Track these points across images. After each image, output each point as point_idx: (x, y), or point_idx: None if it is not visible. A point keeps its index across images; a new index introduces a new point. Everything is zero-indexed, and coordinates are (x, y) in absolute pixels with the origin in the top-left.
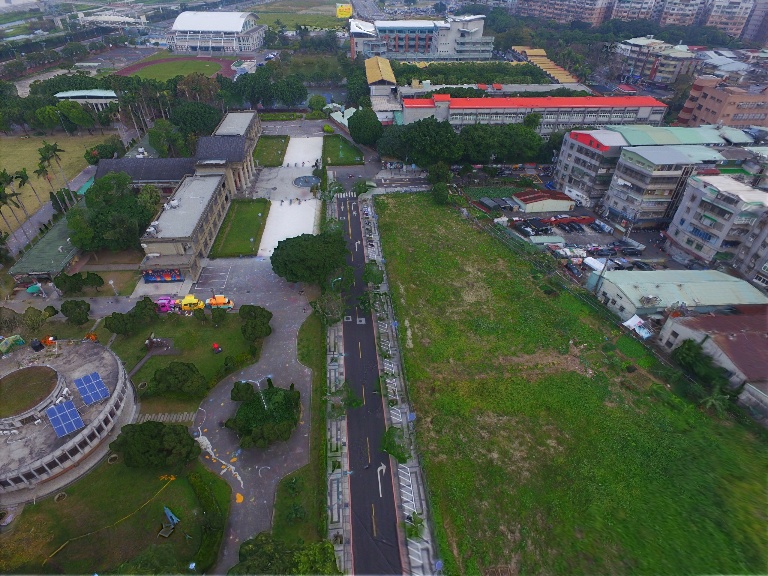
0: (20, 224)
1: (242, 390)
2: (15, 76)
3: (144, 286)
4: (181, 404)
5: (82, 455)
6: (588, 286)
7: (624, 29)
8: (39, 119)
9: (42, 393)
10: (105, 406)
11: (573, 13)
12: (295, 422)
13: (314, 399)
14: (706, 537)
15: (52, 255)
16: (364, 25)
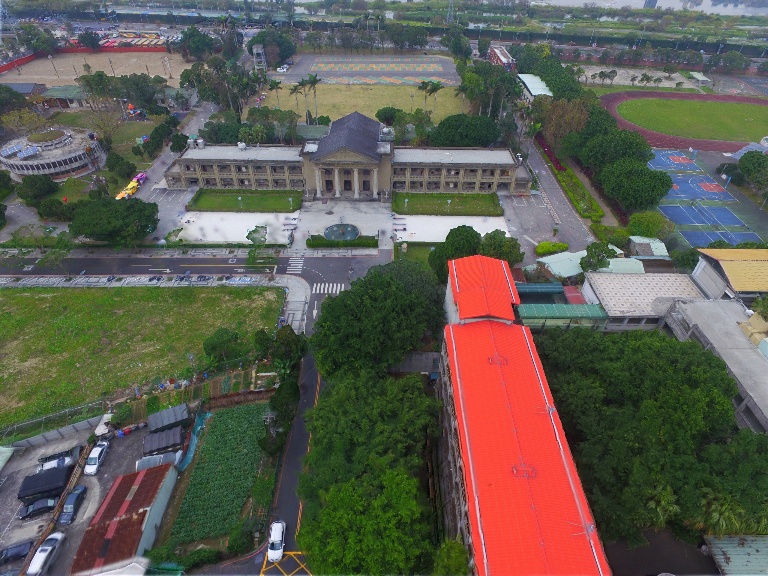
0: None
1: None
2: (620, 62)
3: None
4: None
5: (7, 169)
6: None
7: None
8: None
9: None
10: (15, 160)
11: None
12: None
13: None
14: None
15: None
16: None
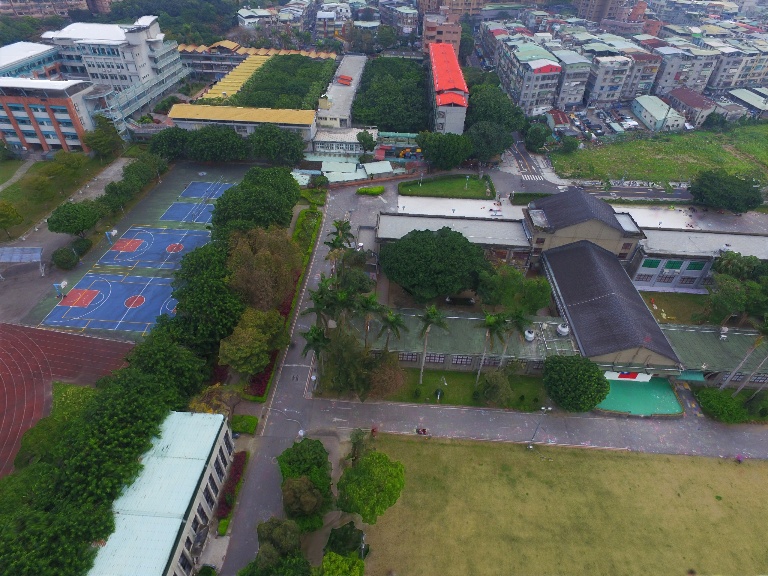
0: None
1: None
2: None
3: None
4: None
5: None
6: None
7: (155, 8)
8: None
9: None
10: None
11: (49, 2)
12: None
13: None
14: None
15: None
16: None
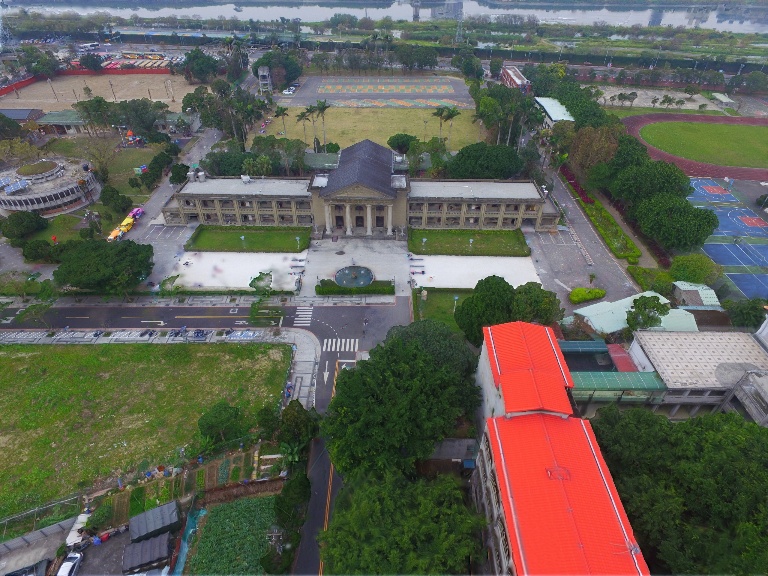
0: None
1: None
2: (638, 82)
3: None
4: None
5: None
6: None
7: None
8: None
9: (26, 173)
10: (2, 195)
11: None
12: None
13: None
14: None
15: None
16: None
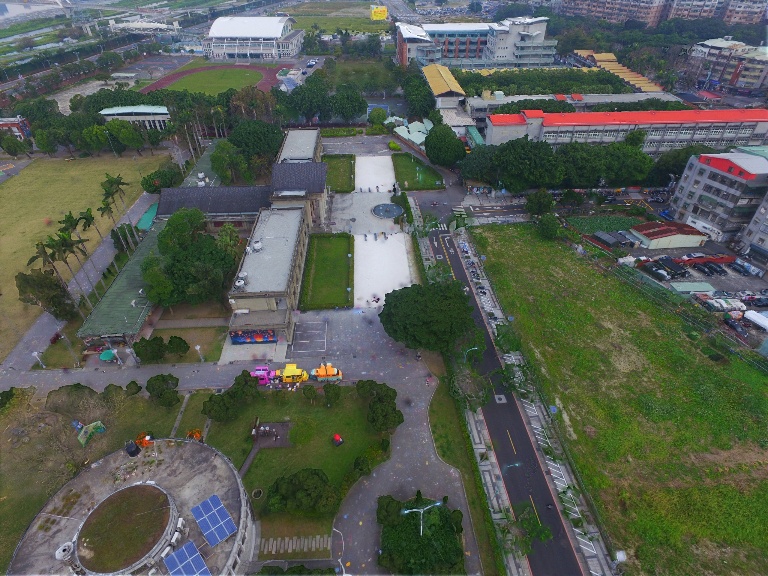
0: (86, 273)
1: (393, 513)
2: (51, 89)
3: (232, 348)
4: (310, 523)
5: None
6: (763, 350)
7: (688, 29)
8: (86, 140)
9: (154, 530)
10: (233, 546)
11: (626, 12)
12: (462, 555)
13: (474, 517)
14: None
15: (124, 311)
16: (412, 29)
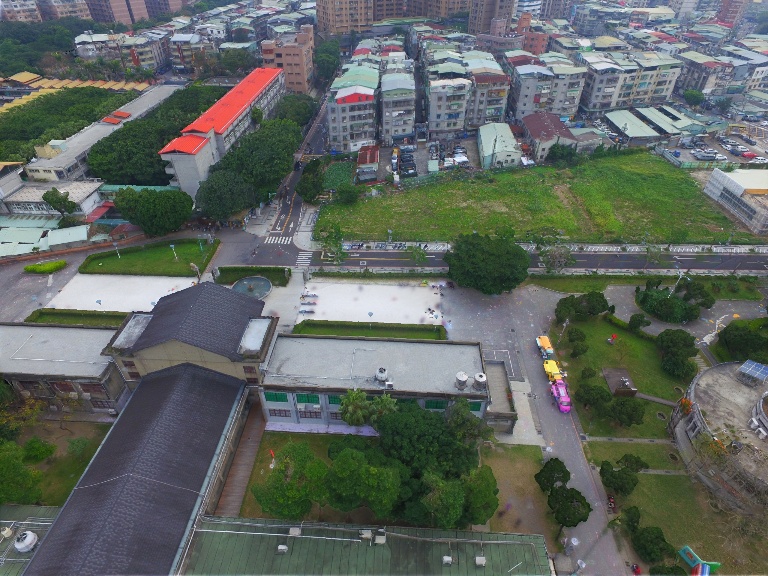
0: None
1: None
2: None
3: (518, 434)
4: None
5: None
6: (487, 166)
7: (2, 36)
8: None
9: None
10: None
11: None
12: None
13: (638, 283)
14: (658, 181)
15: None
16: None
